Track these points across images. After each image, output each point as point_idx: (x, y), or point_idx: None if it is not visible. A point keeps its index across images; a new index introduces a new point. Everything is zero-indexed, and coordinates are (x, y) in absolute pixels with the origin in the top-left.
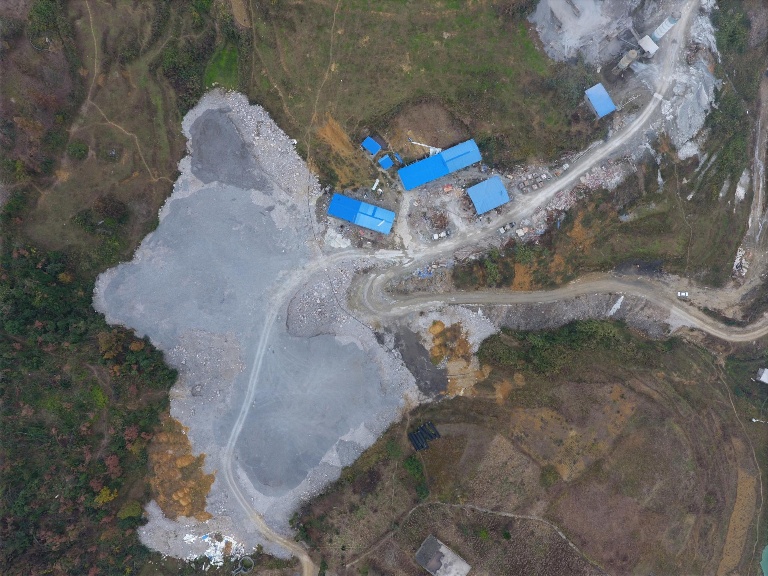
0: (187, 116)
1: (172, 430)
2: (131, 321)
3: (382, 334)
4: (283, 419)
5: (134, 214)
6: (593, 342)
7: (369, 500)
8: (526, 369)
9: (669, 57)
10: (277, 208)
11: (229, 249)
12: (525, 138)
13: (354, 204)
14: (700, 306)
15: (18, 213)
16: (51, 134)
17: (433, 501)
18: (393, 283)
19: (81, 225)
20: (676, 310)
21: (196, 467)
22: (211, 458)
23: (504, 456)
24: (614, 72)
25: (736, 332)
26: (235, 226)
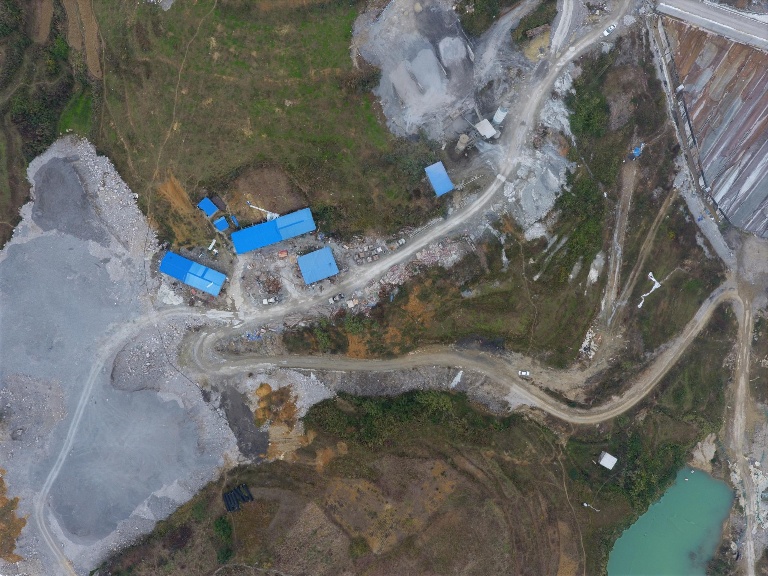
0: (33, 163)
1: None
2: None
3: (209, 392)
4: (98, 470)
5: None
6: (424, 415)
7: (178, 556)
8: (350, 438)
9: (516, 139)
10: (113, 261)
11: (62, 298)
12: (364, 210)
13: (185, 264)
14: (542, 386)
15: None
16: None
17: (239, 563)
18: (223, 343)
19: None
20: (516, 388)
21: (8, 510)
22: (24, 502)
23: (315, 524)
24: (457, 151)
25: (579, 414)
26: (70, 275)
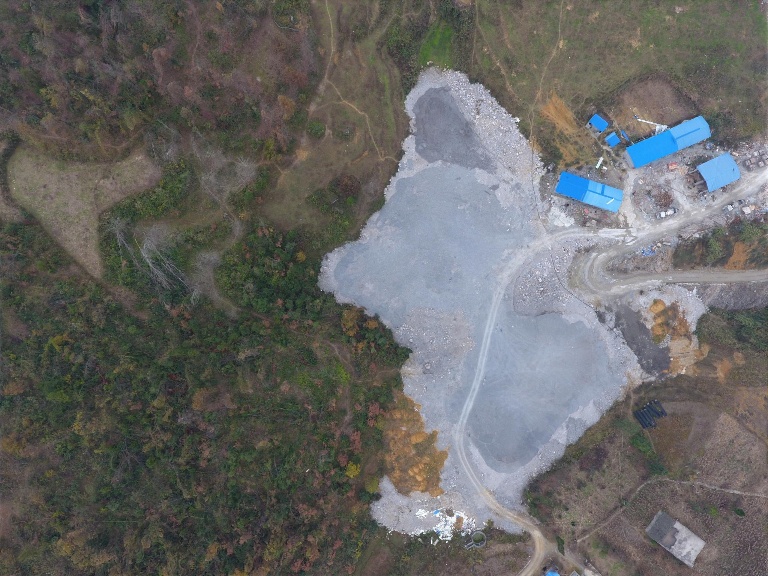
0: (410, 95)
1: (406, 407)
2: (361, 300)
3: (603, 313)
4: (513, 397)
5: (362, 193)
6: None
7: (596, 477)
8: (746, 348)
9: None
10: (501, 187)
11: (455, 228)
12: (751, 114)
13: (582, 182)
14: None
15: (260, 192)
16: (294, 113)
17: (662, 478)
18: (615, 262)
19: (317, 204)
20: None
21: (430, 443)
22: (443, 435)
23: (730, 434)
24: None
25: None
26: (460, 205)
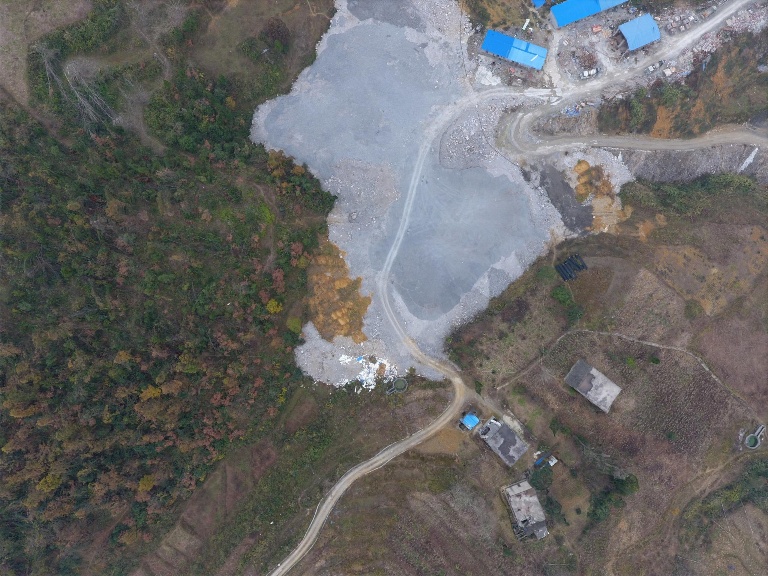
0: None
1: (331, 253)
2: (290, 149)
3: (528, 172)
4: (437, 246)
5: (293, 47)
6: (730, 189)
7: (517, 328)
8: (668, 210)
9: None
10: (430, 45)
11: (384, 83)
12: None
13: (508, 39)
14: None
15: (190, 36)
16: None
17: (581, 329)
18: (540, 122)
19: (247, 52)
20: None
21: (353, 289)
22: (367, 281)
23: (649, 289)
24: None
25: None
26: (390, 61)
